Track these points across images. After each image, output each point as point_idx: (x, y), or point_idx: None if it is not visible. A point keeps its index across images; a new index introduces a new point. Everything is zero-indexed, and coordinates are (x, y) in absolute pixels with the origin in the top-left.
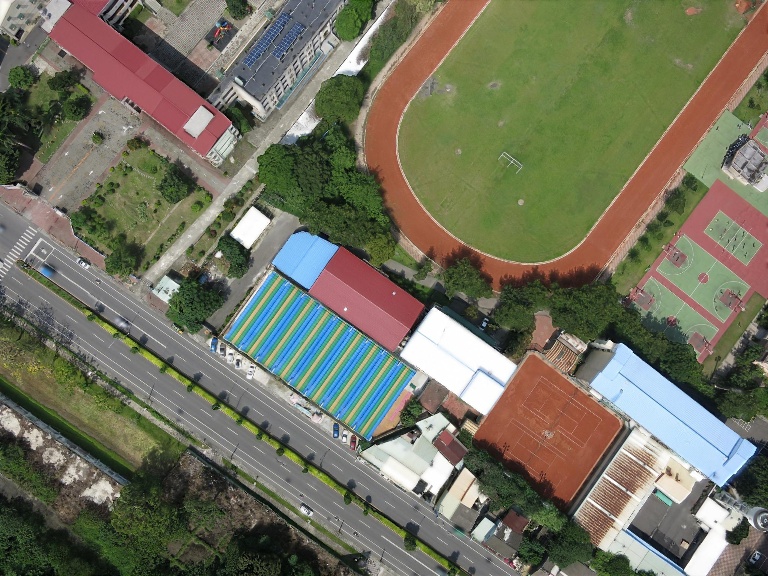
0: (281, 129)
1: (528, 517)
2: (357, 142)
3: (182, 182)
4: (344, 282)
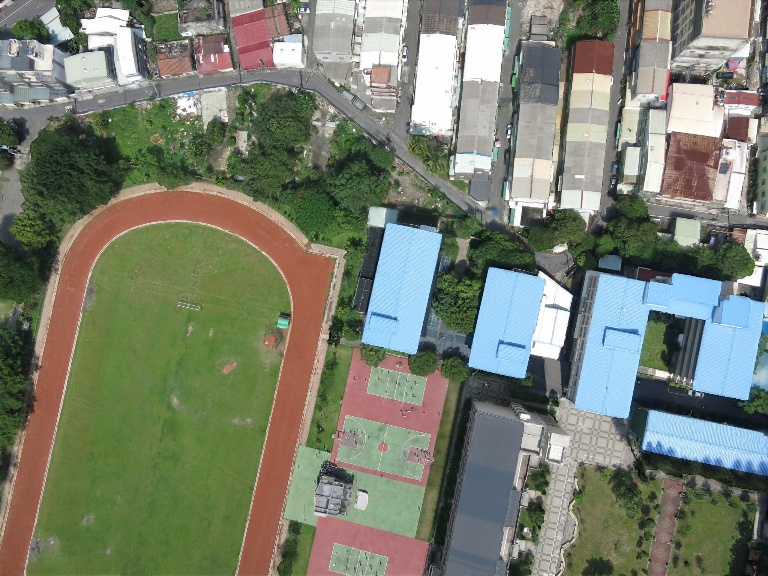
0: None
1: None
2: None
3: None
4: None
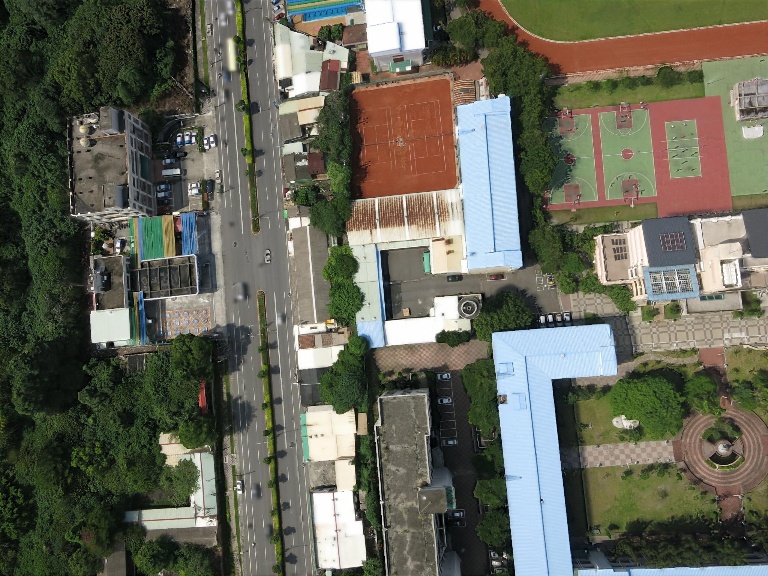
0: None
1: (327, 168)
2: None
3: None
4: None
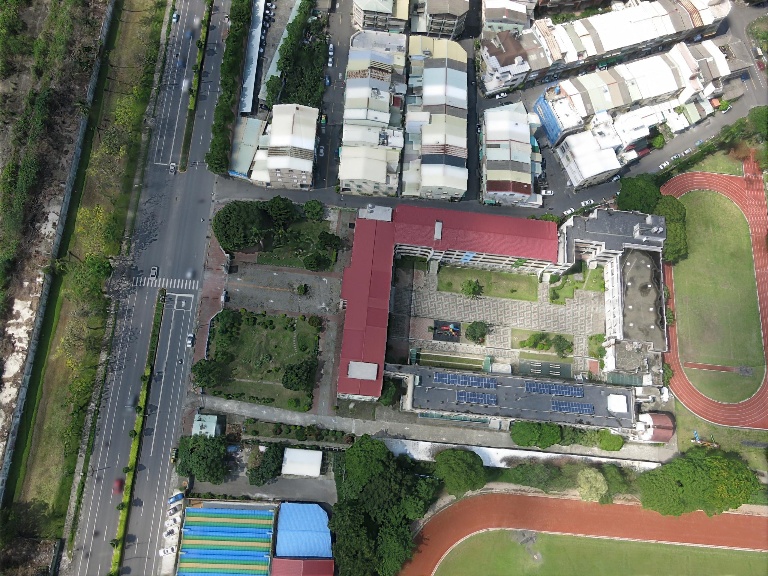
0: (404, 430)
1: None
2: (436, 504)
3: (306, 382)
4: None
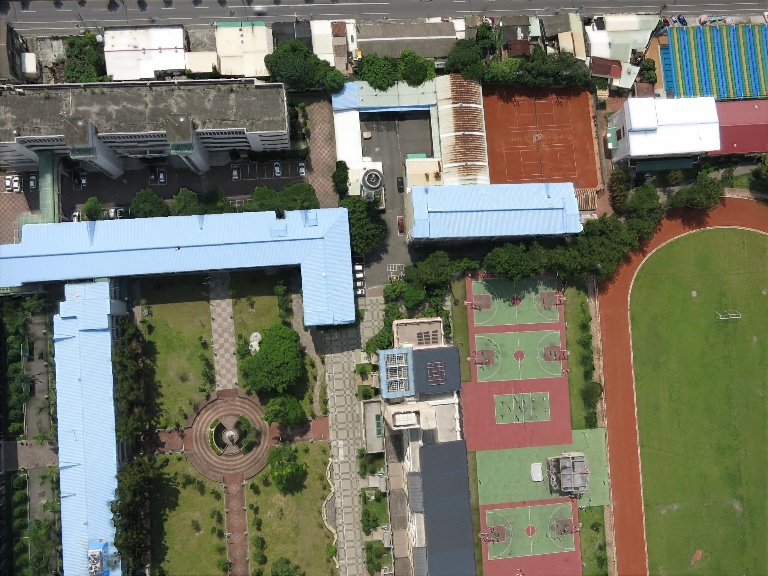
0: None
1: None
2: None
3: None
4: None
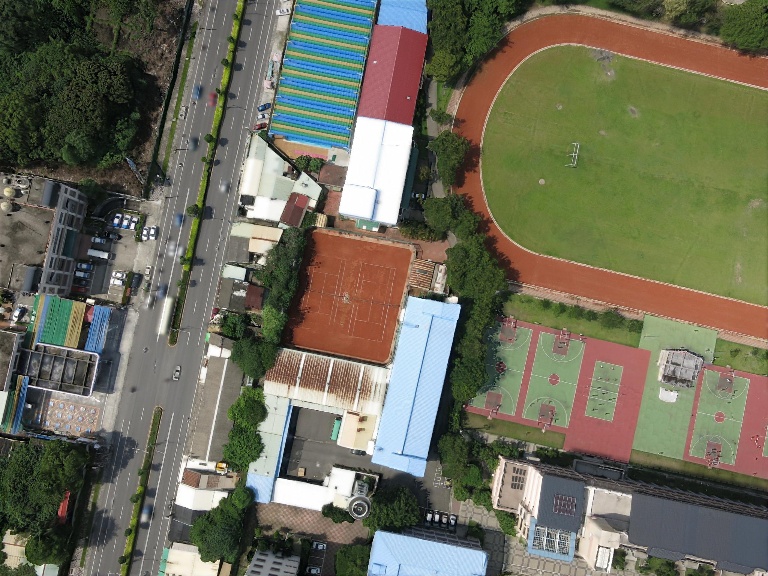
0: None
1: (264, 306)
2: (525, 16)
3: None
4: (398, 49)
